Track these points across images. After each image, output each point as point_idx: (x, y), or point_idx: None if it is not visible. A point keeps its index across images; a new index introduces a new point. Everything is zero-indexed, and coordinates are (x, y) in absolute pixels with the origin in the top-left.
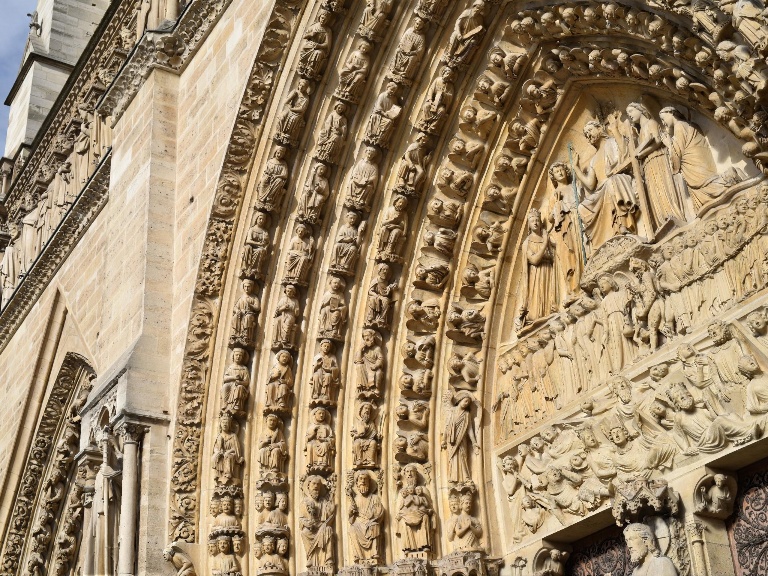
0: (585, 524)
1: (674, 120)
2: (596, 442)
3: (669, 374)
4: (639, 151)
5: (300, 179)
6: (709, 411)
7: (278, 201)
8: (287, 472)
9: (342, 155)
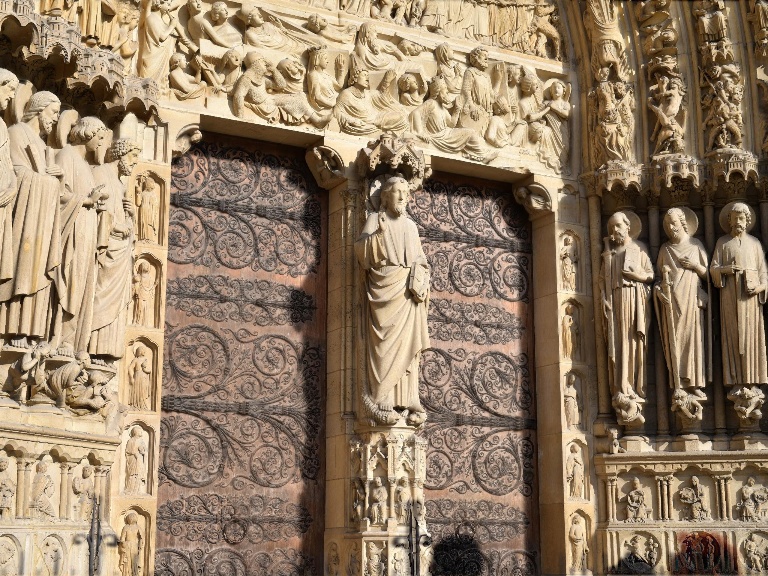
0: (254, 128)
1: None
2: None
3: (419, 57)
4: None
5: None
6: (455, 116)
7: None
8: None
9: None
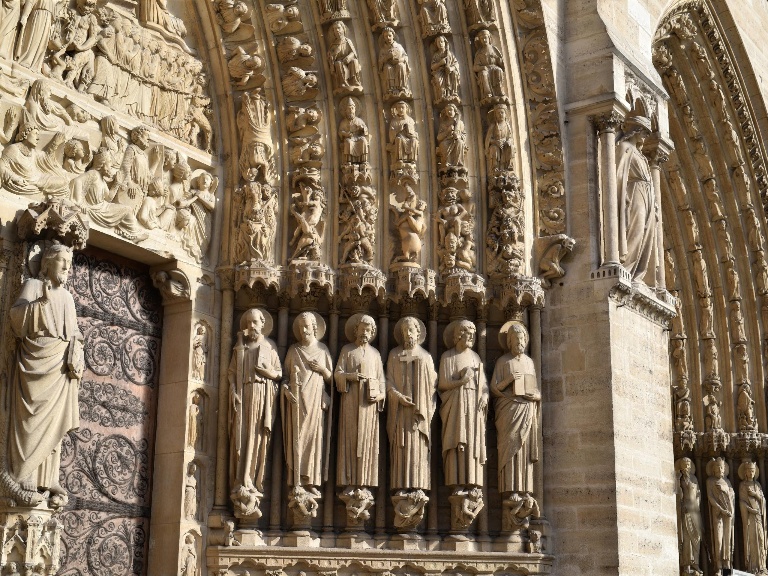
0: None
1: None
2: None
3: None
4: None
5: None
6: (114, 190)
7: None
8: None
9: None
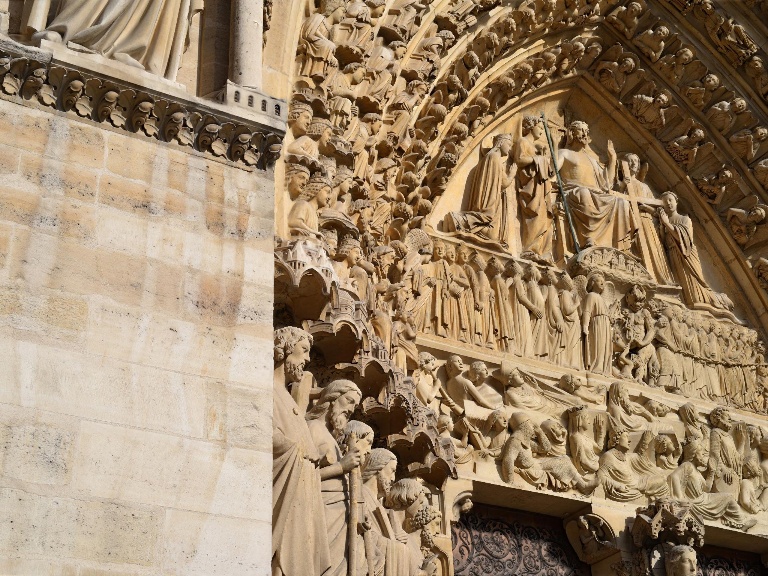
0: (521, 495)
1: None
2: None
3: None
4: (645, 202)
5: None
6: (710, 479)
7: None
8: None
9: None
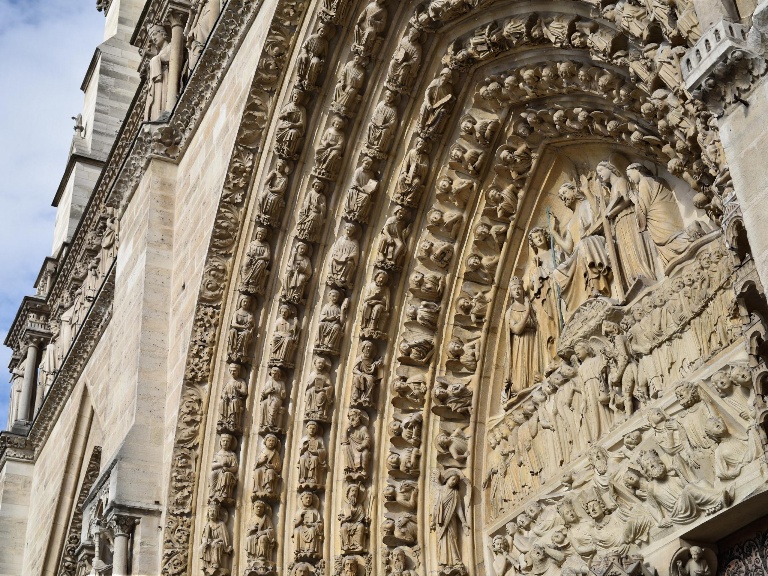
0: None
1: (640, 176)
2: (576, 517)
3: (642, 441)
4: (609, 211)
5: (283, 259)
6: (680, 479)
7: (262, 283)
8: (275, 560)
9: (323, 233)
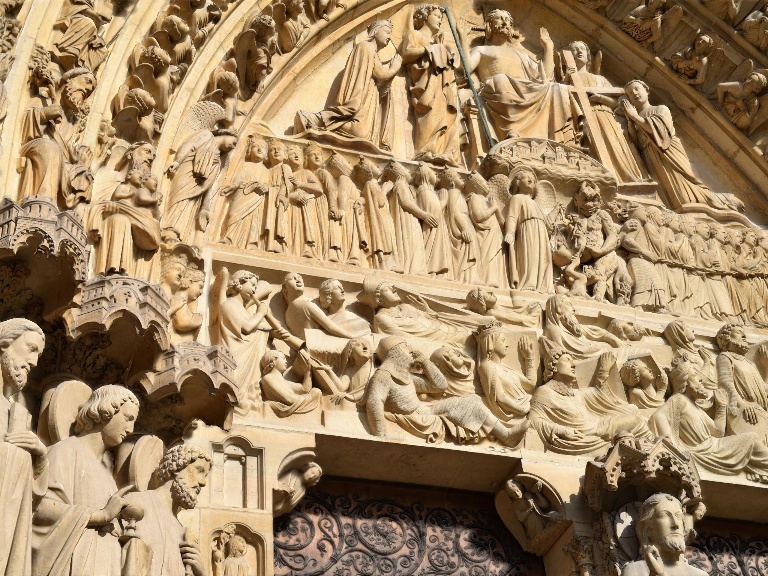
0: (406, 455)
1: None
2: None
3: (643, 342)
4: (598, 91)
5: None
6: (720, 418)
7: None
8: None
9: None
